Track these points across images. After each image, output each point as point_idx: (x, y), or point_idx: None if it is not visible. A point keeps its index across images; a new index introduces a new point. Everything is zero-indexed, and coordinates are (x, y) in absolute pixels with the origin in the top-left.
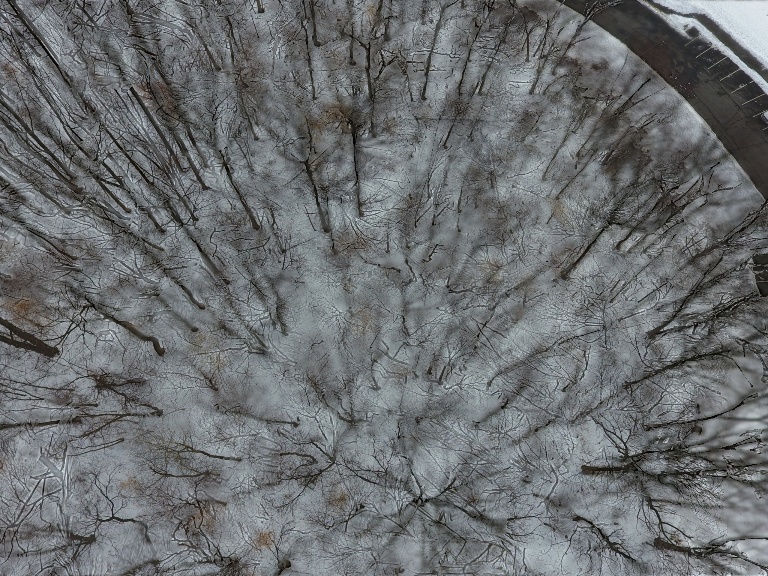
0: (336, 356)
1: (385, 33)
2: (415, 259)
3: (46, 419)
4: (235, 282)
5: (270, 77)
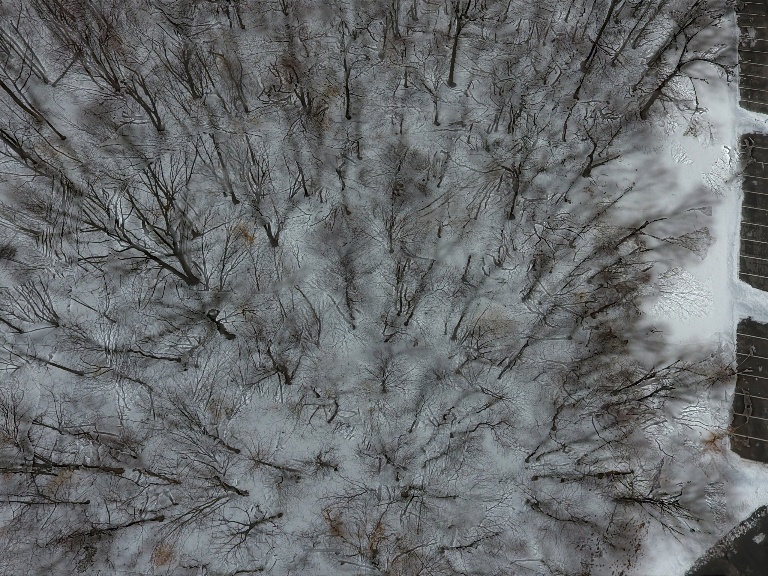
0: (382, 0)
1: None
2: None
3: (159, 6)
4: None
5: None
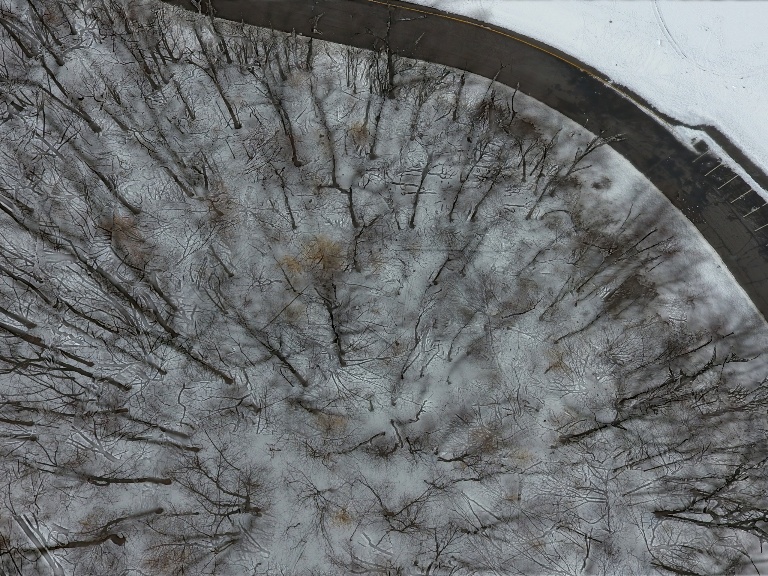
0: (313, 544)
1: (371, 152)
2: (401, 419)
3: None
4: (205, 451)
5: (243, 224)
